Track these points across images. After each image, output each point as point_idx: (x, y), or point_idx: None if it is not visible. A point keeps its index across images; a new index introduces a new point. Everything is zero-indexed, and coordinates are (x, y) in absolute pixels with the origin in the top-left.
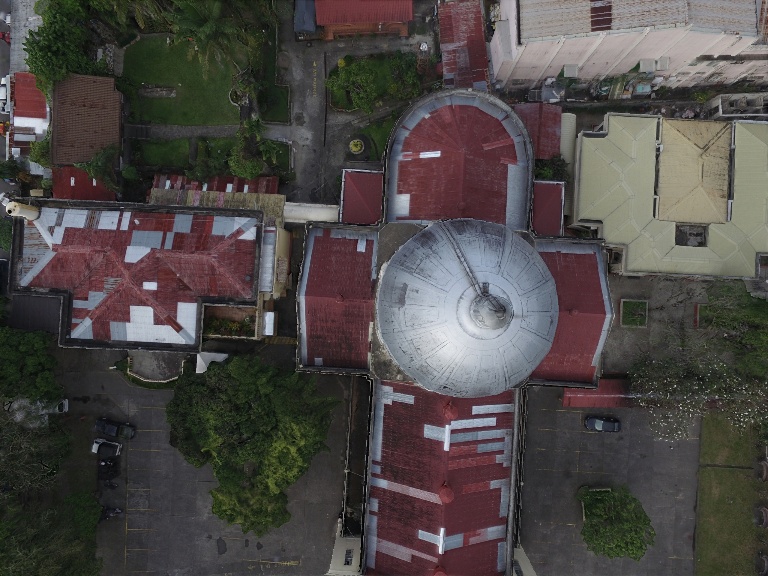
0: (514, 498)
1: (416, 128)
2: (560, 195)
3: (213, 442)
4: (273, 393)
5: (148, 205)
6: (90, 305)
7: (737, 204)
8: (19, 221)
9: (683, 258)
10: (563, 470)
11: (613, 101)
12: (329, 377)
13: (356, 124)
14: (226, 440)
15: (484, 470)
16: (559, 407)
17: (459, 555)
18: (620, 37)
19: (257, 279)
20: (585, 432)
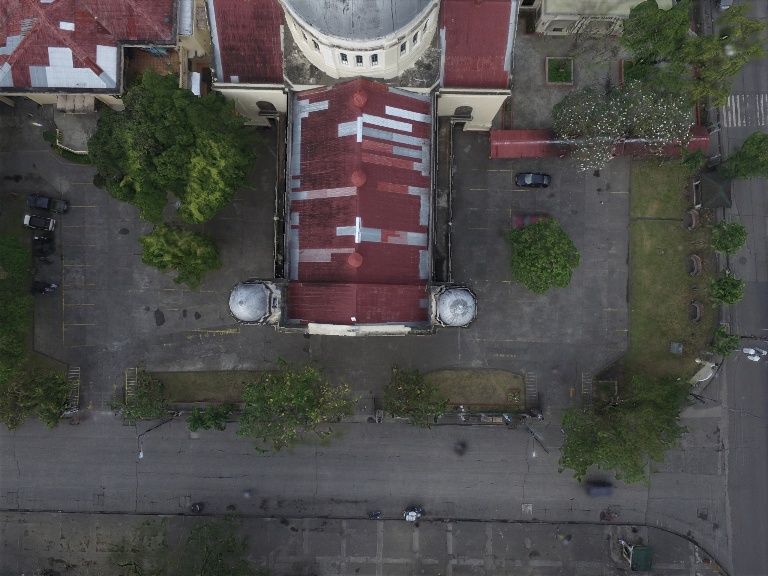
0: (432, 200)
1: None
2: None
3: (132, 164)
4: (188, 106)
5: None
6: (8, 50)
7: None
8: None
9: None
10: (496, 228)
11: None
12: (260, 146)
13: None
14: None
15: (401, 173)
16: (490, 167)
17: (377, 250)
18: None
19: (176, 20)
20: (516, 191)
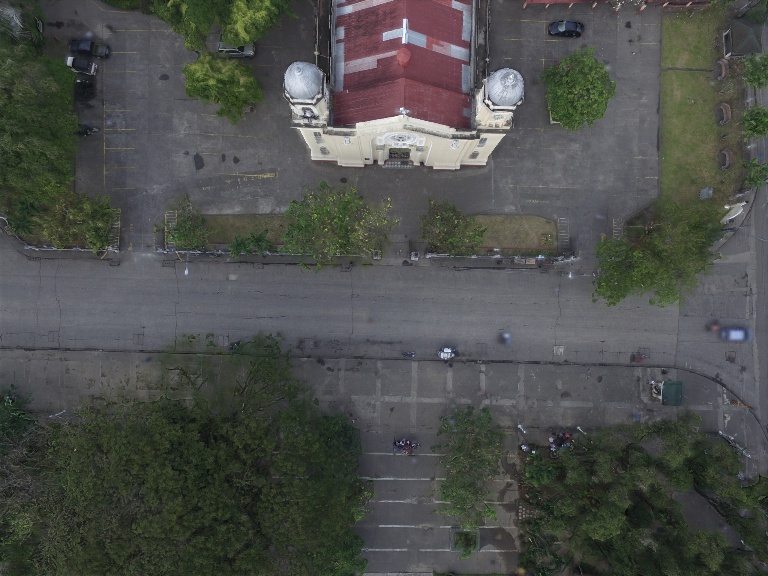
0: (475, 13)
1: None
2: None
3: None
4: None
5: None
6: None
7: None
8: None
9: None
10: (529, 77)
11: None
12: None
13: None
14: None
15: None
16: (523, 17)
17: (423, 54)
18: None
19: None
20: (549, 41)
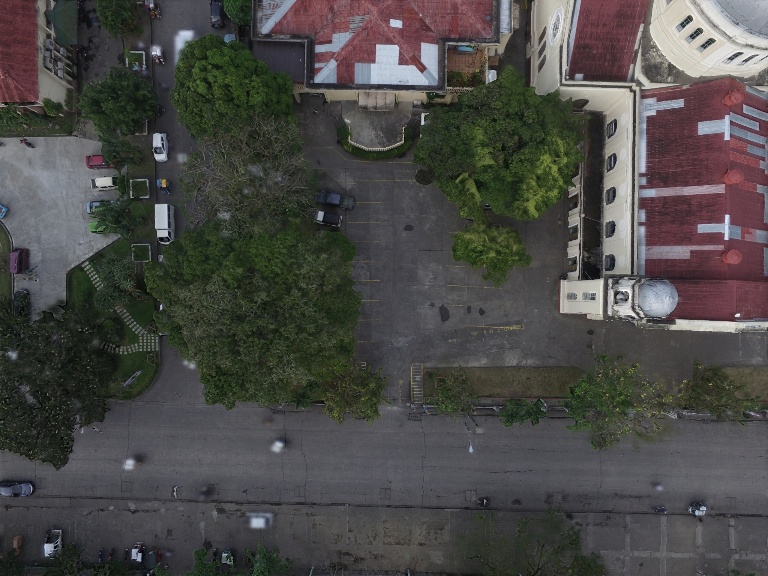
0: None
1: None
2: None
3: (478, 161)
4: (542, 104)
5: None
6: (335, 47)
7: None
8: None
9: None
10: None
11: None
12: None
13: None
14: None
15: (752, 171)
16: None
17: (738, 247)
18: None
19: (497, 18)
20: None
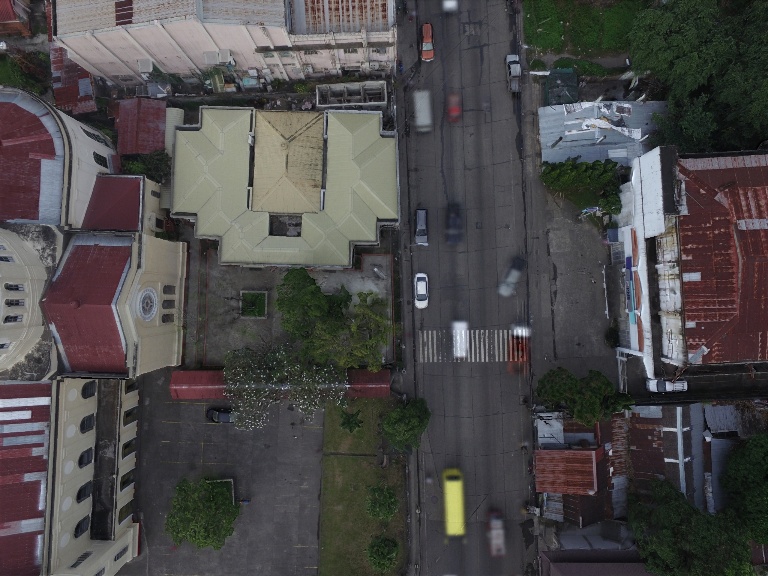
0: None
1: None
2: (139, 189)
3: None
4: None
5: None
6: None
7: (329, 193)
8: None
9: (274, 248)
10: (187, 462)
11: (218, 94)
12: None
13: None
14: None
15: (14, 463)
16: (183, 399)
17: None
18: (143, 30)
19: None
20: (209, 424)
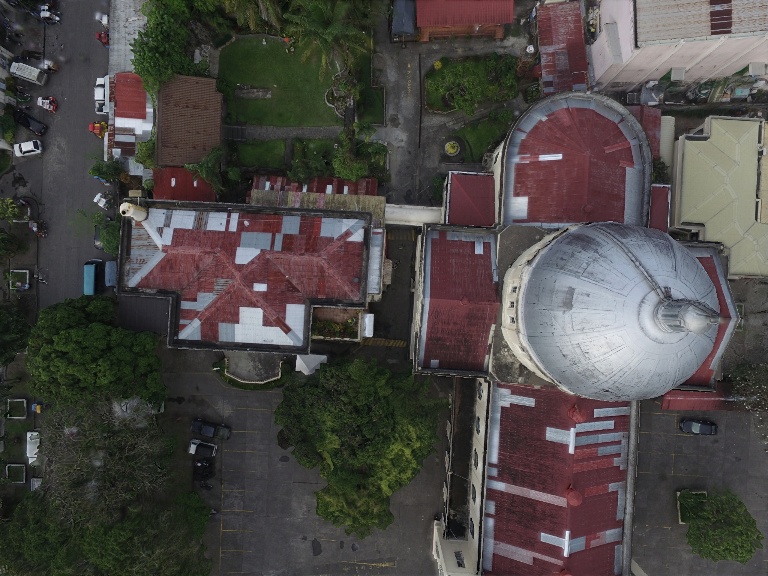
0: (633, 501)
1: (533, 131)
2: (666, 198)
3: (329, 444)
4: (392, 395)
5: (256, 206)
6: (199, 306)
7: None
8: (127, 222)
9: None
10: (658, 473)
11: (712, 104)
12: None
13: (451, 126)
14: (345, 442)
15: (603, 473)
16: (654, 410)
17: (582, 558)
18: (740, 41)
19: (365, 281)
20: (680, 435)
